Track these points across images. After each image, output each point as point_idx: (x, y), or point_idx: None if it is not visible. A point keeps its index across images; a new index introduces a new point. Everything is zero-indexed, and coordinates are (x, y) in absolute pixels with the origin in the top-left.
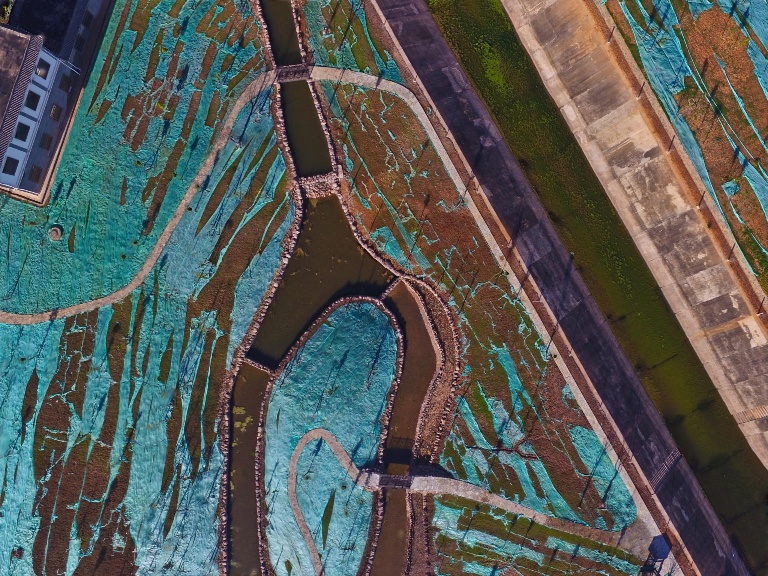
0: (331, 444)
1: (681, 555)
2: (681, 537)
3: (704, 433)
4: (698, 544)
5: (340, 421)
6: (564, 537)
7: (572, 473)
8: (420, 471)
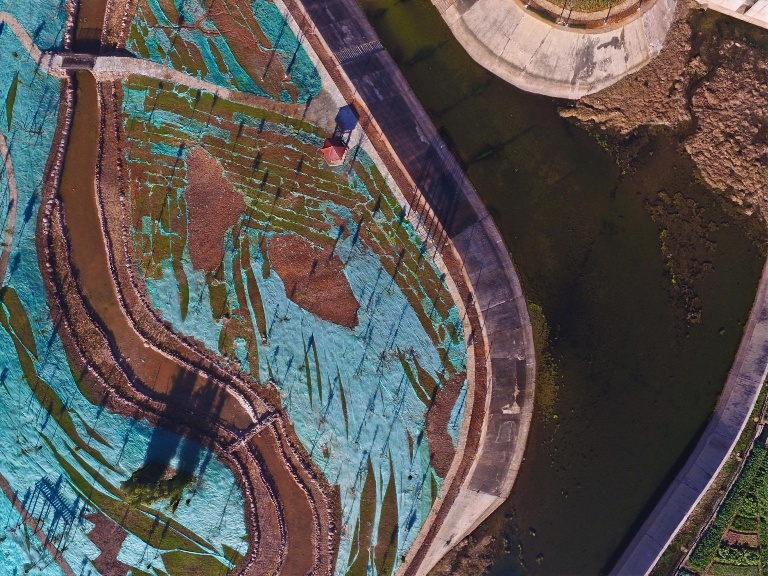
0: (12, 26)
1: (369, 126)
2: (369, 108)
3: (407, 26)
4: (392, 122)
5: (20, 3)
6: (248, 111)
7: (255, 47)
8: (105, 55)
